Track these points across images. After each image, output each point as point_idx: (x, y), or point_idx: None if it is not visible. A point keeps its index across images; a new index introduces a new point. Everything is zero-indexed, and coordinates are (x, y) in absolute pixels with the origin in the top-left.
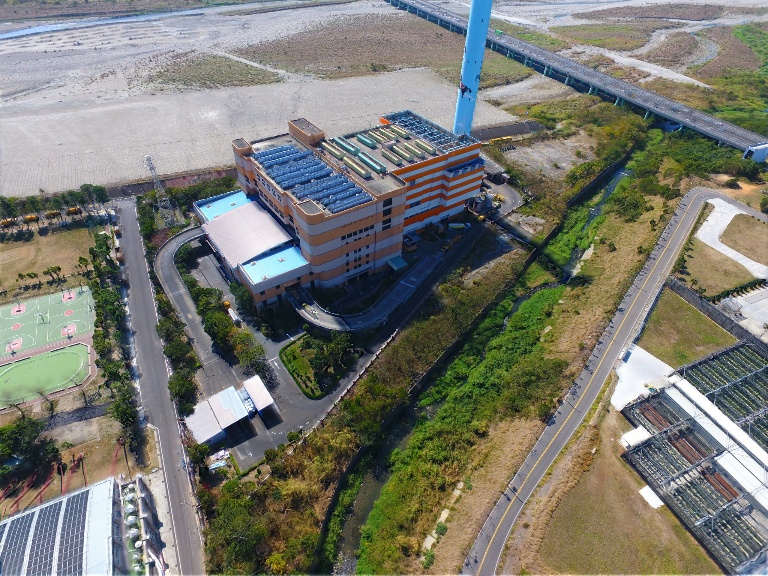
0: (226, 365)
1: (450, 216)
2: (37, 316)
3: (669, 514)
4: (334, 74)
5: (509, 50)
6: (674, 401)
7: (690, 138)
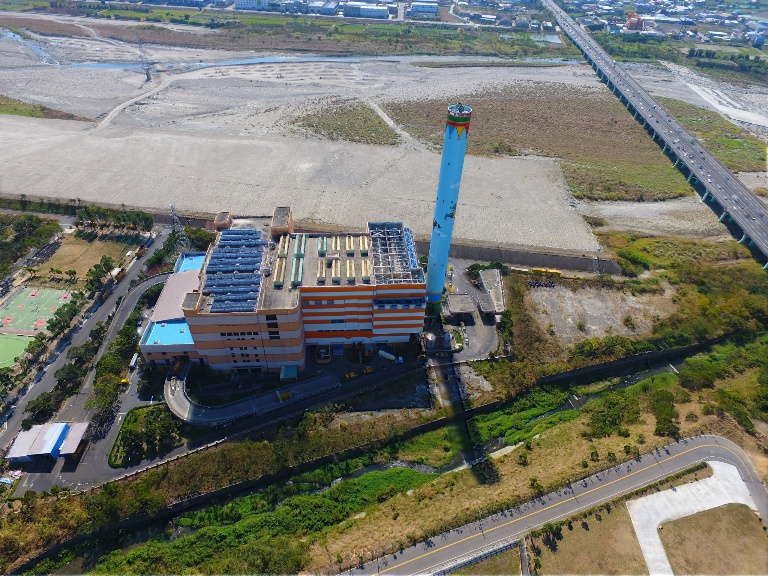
0: None
1: (390, 342)
2: None
3: None
4: None
5: (678, 159)
6: None
7: None
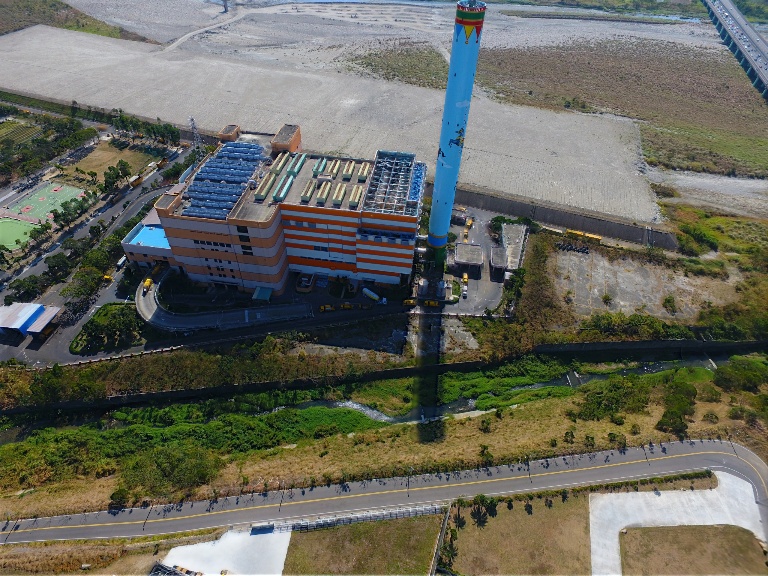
0: None
1: (378, 282)
2: None
3: None
4: (515, 97)
5: None
6: None
7: None
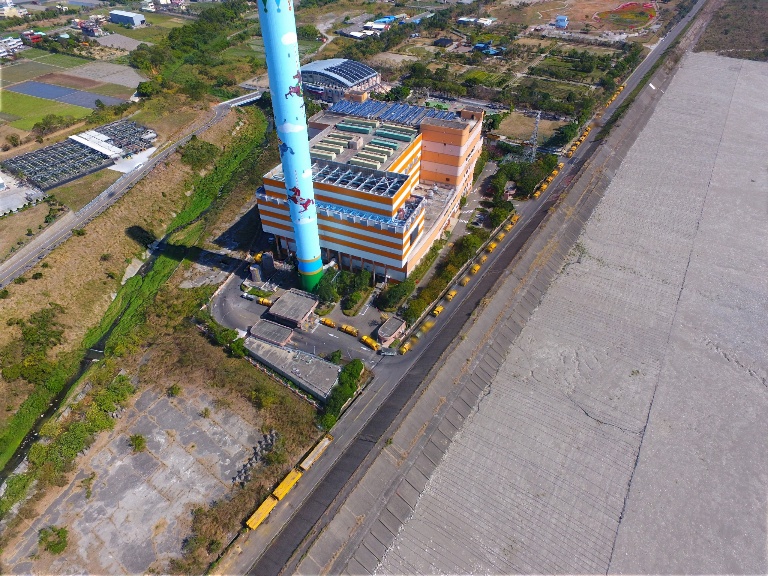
0: None
1: None
2: None
3: None
4: None
5: None
6: None
7: None
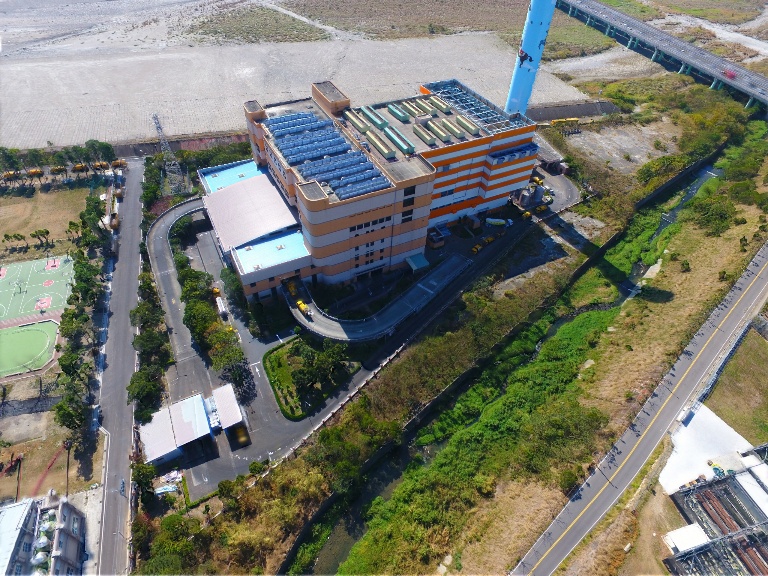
0: (202, 364)
1: (490, 209)
2: (14, 284)
3: None
4: (386, 34)
5: (590, 16)
6: (747, 493)
7: None
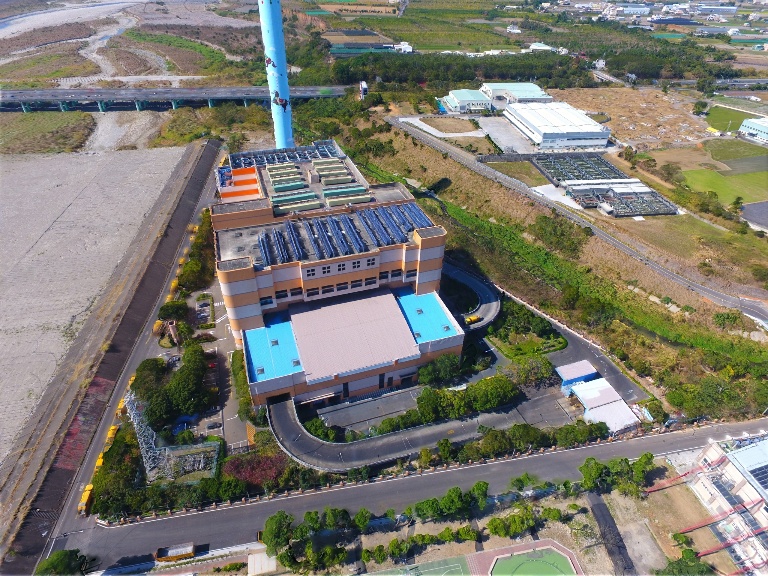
0: (527, 404)
1: None
2: None
3: (647, 217)
4: None
5: (22, 103)
6: (580, 189)
7: (294, 105)
